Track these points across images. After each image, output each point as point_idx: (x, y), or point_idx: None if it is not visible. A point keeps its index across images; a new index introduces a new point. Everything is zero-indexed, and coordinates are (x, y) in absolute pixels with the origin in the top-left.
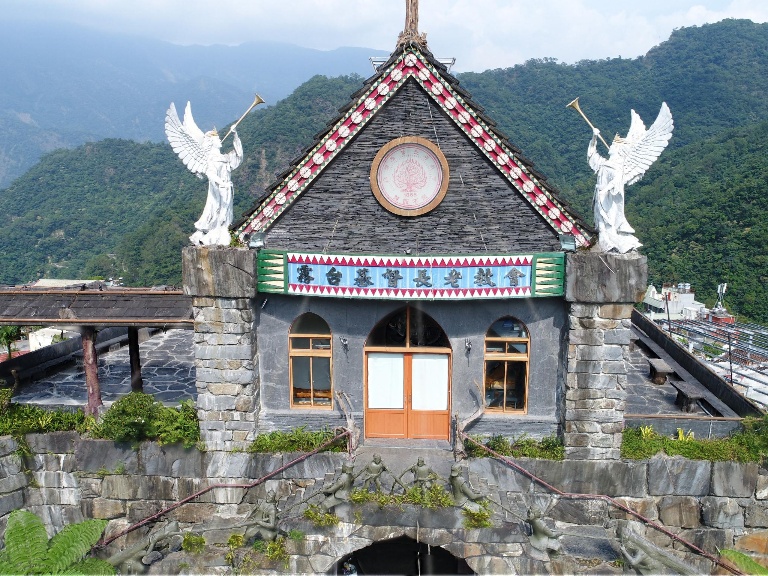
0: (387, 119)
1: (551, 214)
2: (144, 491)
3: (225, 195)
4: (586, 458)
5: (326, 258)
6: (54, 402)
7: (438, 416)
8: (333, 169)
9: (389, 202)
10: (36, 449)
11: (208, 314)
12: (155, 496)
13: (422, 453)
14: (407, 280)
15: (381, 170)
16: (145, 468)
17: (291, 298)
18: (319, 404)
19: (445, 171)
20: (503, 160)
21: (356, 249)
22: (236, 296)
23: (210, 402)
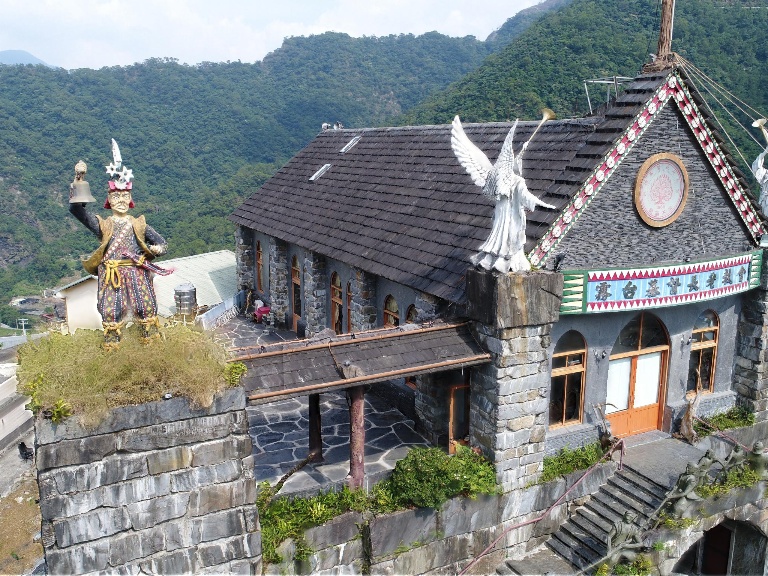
0: (648, 136)
1: (749, 218)
2: (441, 558)
3: (522, 217)
4: (765, 419)
5: (626, 273)
6: None
7: (651, 409)
8: (606, 185)
9: (647, 215)
10: (313, 547)
11: (516, 346)
12: (450, 560)
13: (659, 445)
14: (683, 286)
15: (642, 185)
16: (444, 531)
17: (559, 318)
18: (567, 421)
19: (686, 184)
20: (725, 173)
21: (617, 262)
22: (545, 322)
23: (508, 440)
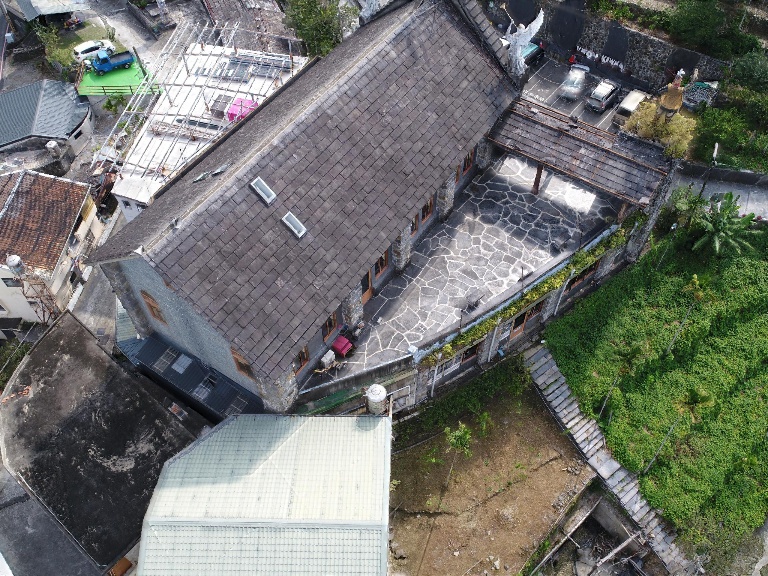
0: None
1: None
2: None
3: None
4: None
5: None
6: (577, 203)
7: None
8: None
9: None
10: None
11: None
12: None
13: None
14: None
15: None
16: None
17: None
18: None
19: None
20: None
21: None
22: None
23: None
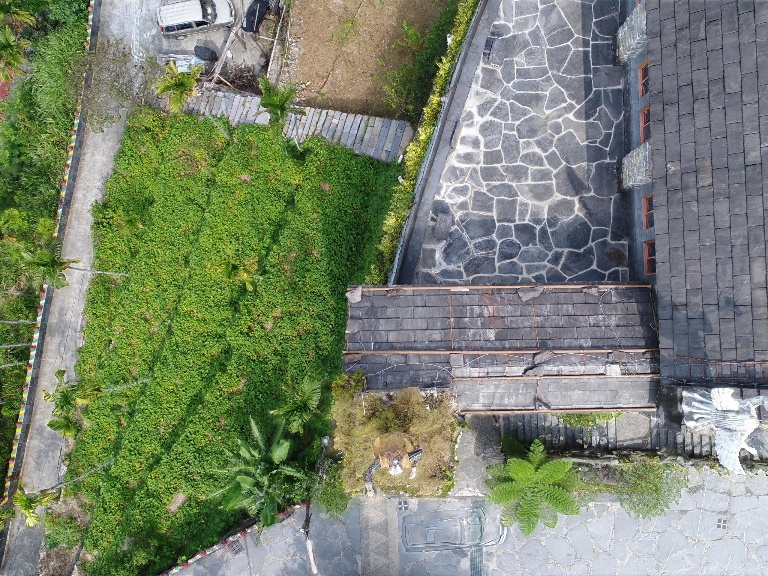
0: None
1: None
2: None
3: None
4: None
5: None
6: None
7: None
8: None
9: None
10: None
11: None
12: None
13: None
14: None
15: None
16: None
17: None
18: None
19: None
20: None
21: None
22: None
23: None
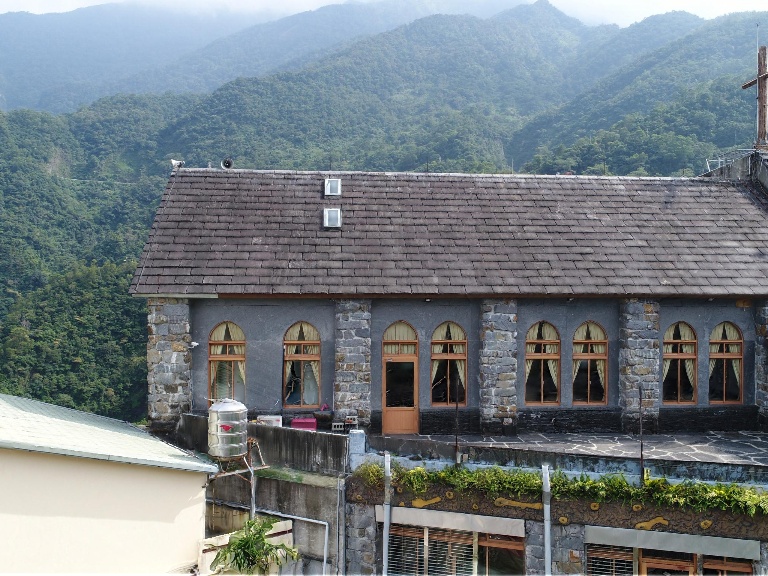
0: None
1: None
2: None
3: None
4: None
5: None
6: None
7: None
8: None
9: None
10: None
11: None
12: None
13: None
14: None
15: None
16: None
17: None
18: None
19: None
20: None
21: None
22: None
23: None
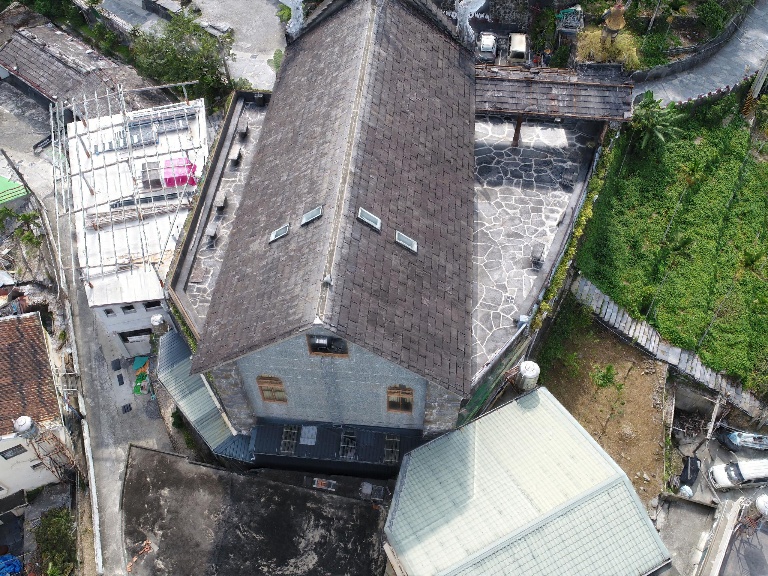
0: None
1: None
2: None
3: None
4: None
5: None
6: (554, 141)
7: None
8: None
9: None
10: None
11: None
12: None
13: None
14: None
15: None
16: None
17: None
18: None
19: None
20: None
21: None
22: None
23: None
